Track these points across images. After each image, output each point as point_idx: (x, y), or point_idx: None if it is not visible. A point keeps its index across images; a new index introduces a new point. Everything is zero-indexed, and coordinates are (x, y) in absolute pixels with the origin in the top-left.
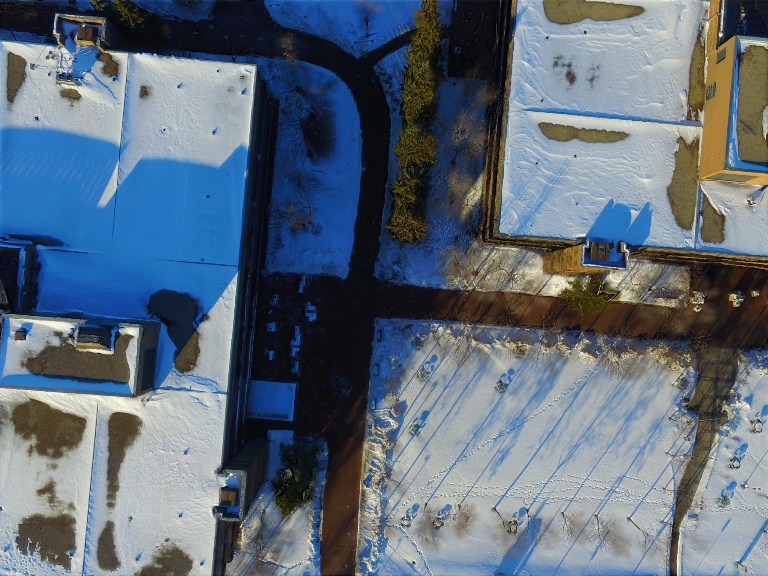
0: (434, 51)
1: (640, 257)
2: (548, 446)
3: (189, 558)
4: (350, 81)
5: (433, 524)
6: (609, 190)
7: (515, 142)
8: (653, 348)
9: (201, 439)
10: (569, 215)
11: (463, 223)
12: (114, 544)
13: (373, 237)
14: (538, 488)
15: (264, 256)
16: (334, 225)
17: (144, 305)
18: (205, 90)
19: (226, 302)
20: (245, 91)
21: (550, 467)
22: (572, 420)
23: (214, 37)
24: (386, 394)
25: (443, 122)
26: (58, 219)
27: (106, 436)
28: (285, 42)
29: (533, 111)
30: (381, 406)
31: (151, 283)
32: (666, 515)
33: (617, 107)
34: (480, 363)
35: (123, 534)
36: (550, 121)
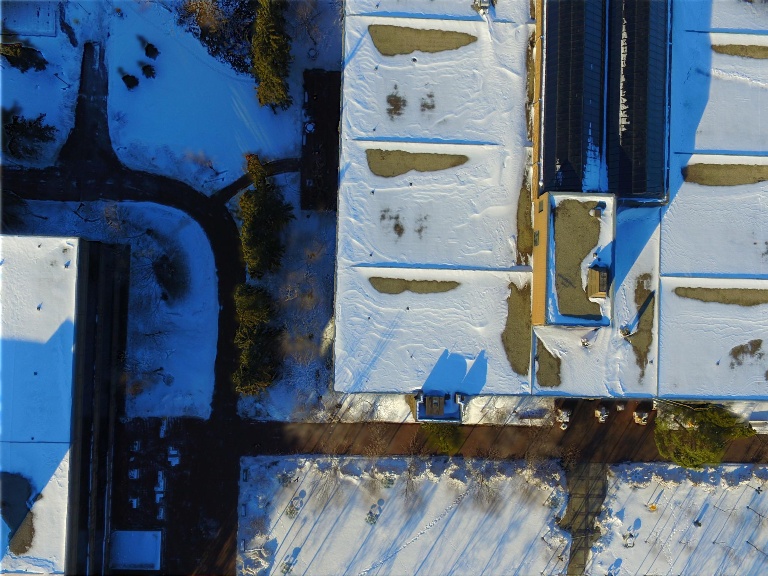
0: (254, 218)
1: None
2: (422, 575)
3: None
4: (202, 220)
5: None
6: (443, 340)
7: (345, 299)
8: (521, 469)
9: None
10: (404, 368)
11: (323, 357)
12: None
13: None
14: None
15: (123, 403)
16: (193, 367)
17: None
18: (27, 266)
19: (59, 480)
20: (69, 264)
21: None
22: (445, 547)
23: (62, 184)
24: (255, 534)
25: (292, 262)
26: None
27: None
28: (109, 211)
29: (362, 267)
30: (251, 546)
31: None
32: None
33: (446, 257)
34: (349, 495)
35: None
36: (380, 275)
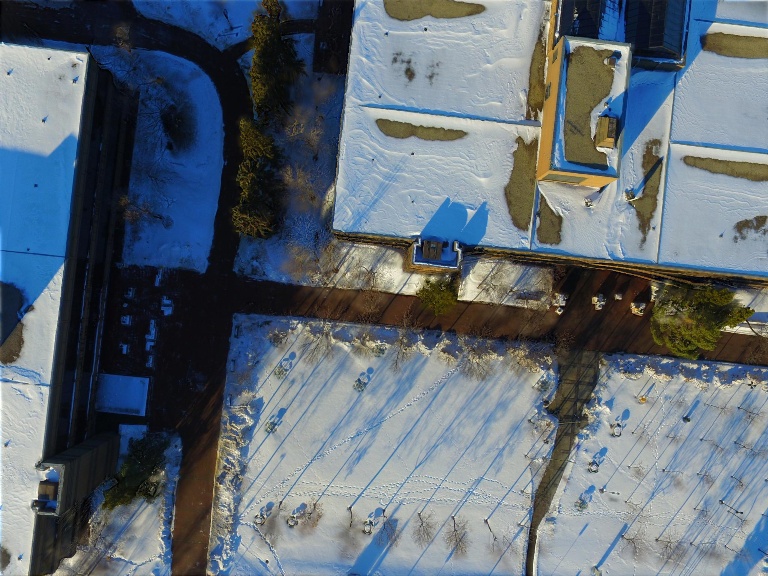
0: (265, 44)
1: (498, 258)
2: (406, 446)
3: (7, 552)
4: (213, 74)
5: (287, 523)
6: (446, 188)
7: (351, 138)
8: (513, 350)
9: (22, 432)
10: (404, 213)
11: (323, 220)
12: None
13: (233, 232)
14: (395, 488)
15: (120, 248)
16: (193, 219)
17: None
18: (36, 78)
19: (52, 293)
20: (77, 80)
21: (407, 467)
22: (431, 420)
23: (76, 26)
24: (242, 390)
25: (300, 117)
26: None
27: None
28: (121, 31)
29: (370, 107)
30: (237, 403)
31: None
32: (523, 518)
33: (455, 105)
34: (339, 361)
35: None
36: (387, 118)
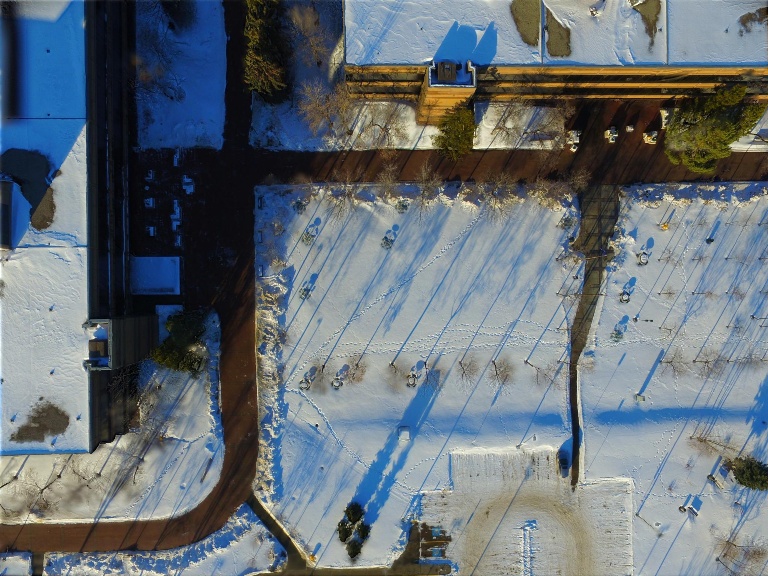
0: None
1: (509, 98)
2: (439, 298)
3: (65, 414)
4: None
5: (332, 385)
6: (452, 12)
7: None
8: (533, 191)
9: (65, 295)
10: (415, 40)
11: (332, 82)
12: None
13: (245, 106)
14: (433, 340)
15: (135, 133)
16: (203, 96)
17: None
18: None
19: (77, 155)
20: None
21: (443, 318)
22: (460, 270)
23: None
24: (272, 260)
25: None
26: None
27: None
28: None
29: None
30: (269, 273)
31: None
32: (562, 354)
33: None
34: (364, 222)
35: None
36: None
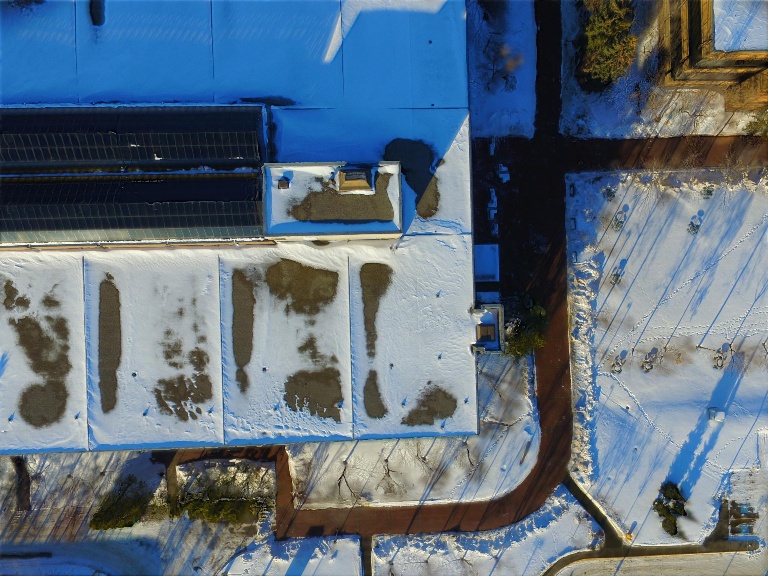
0: None
1: None
2: (743, 281)
3: (453, 397)
4: None
5: (642, 368)
6: None
7: None
8: None
9: (451, 281)
10: None
11: (642, 70)
12: (379, 392)
13: (554, 95)
14: (738, 322)
15: None
16: (517, 86)
17: (380, 156)
18: None
19: (460, 144)
20: None
21: (748, 301)
22: (764, 253)
23: None
24: (584, 247)
25: None
26: (287, 78)
27: (359, 288)
28: None
29: None
30: (580, 259)
31: (385, 133)
32: None
33: None
34: (670, 208)
35: (386, 381)
36: None
